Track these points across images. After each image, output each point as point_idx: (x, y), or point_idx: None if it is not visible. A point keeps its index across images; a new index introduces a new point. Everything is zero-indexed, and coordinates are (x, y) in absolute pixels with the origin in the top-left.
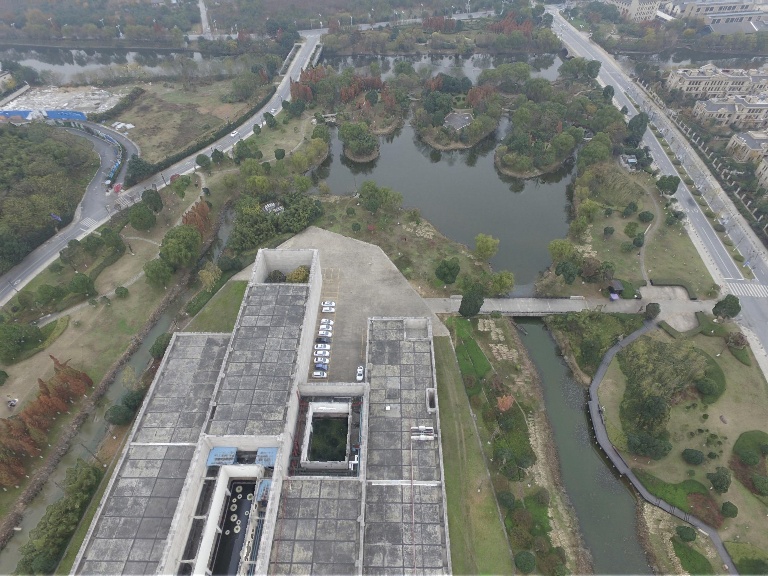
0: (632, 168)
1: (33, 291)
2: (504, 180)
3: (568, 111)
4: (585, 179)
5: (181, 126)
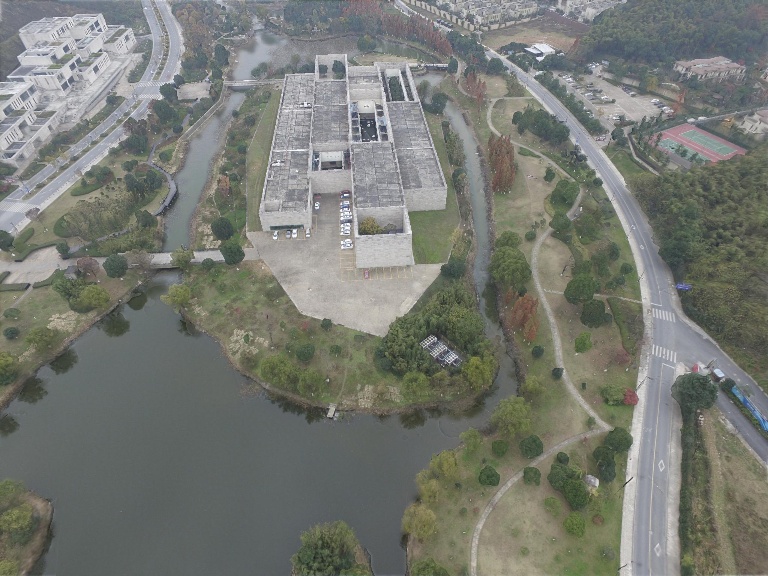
0: None
1: (615, 239)
2: None
3: None
4: None
5: None
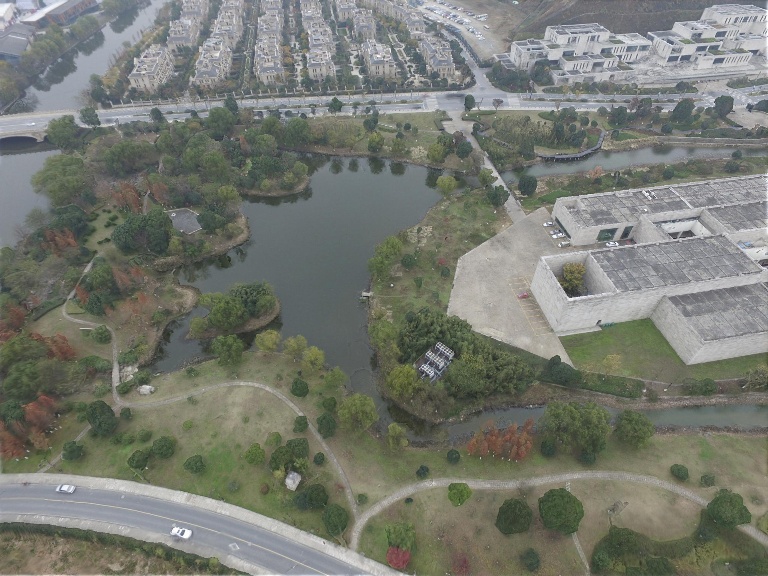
0: None
1: None
2: (295, 200)
3: (174, 146)
4: None
5: None
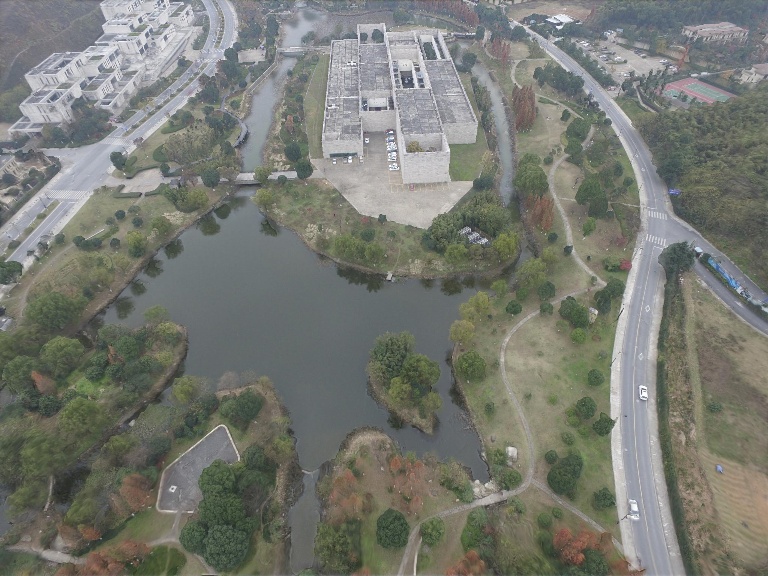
0: (4, 322)
1: None
2: None
3: None
4: (105, 269)
5: (765, 403)
